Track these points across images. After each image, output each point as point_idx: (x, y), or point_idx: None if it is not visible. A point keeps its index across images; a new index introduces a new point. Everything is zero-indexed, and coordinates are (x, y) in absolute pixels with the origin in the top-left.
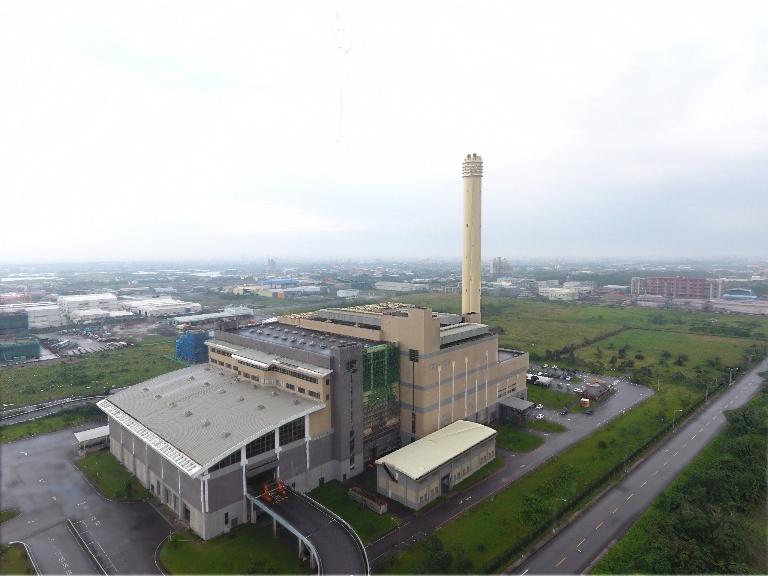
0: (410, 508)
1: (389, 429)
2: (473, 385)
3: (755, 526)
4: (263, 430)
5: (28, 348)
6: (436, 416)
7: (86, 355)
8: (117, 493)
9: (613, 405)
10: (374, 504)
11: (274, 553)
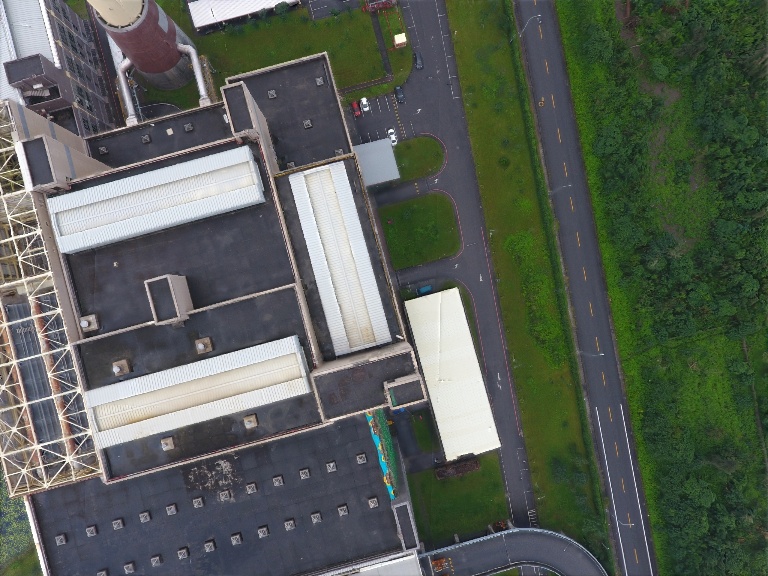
0: None
1: None
2: None
3: (658, 191)
4: None
5: None
6: None
7: None
8: None
9: (418, 2)
10: None
11: None
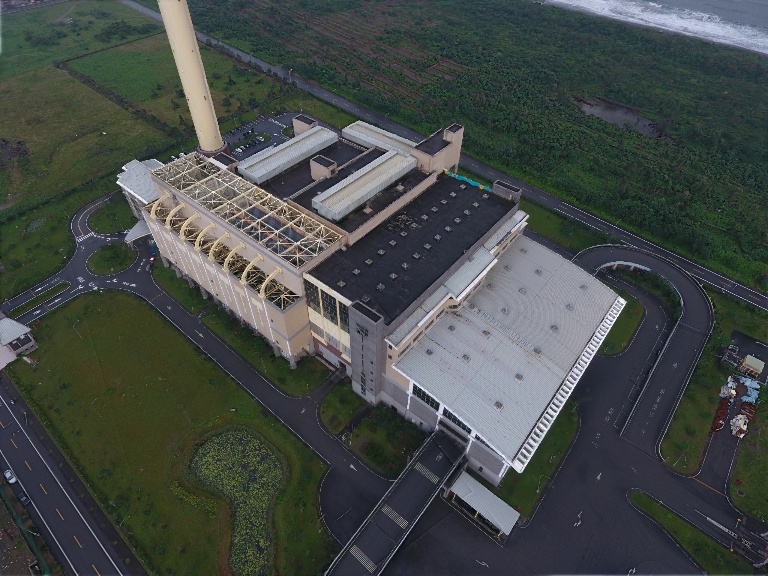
0: None
1: None
2: None
3: (488, 143)
4: None
5: None
6: None
7: None
8: None
9: None
10: None
11: None
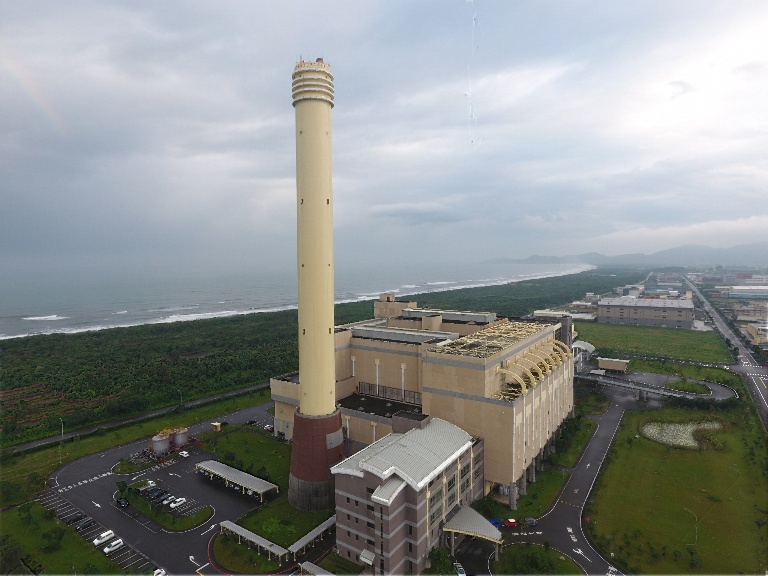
0: None
1: None
2: None
3: None
4: None
5: None
6: None
7: None
8: None
9: None
10: None
11: None
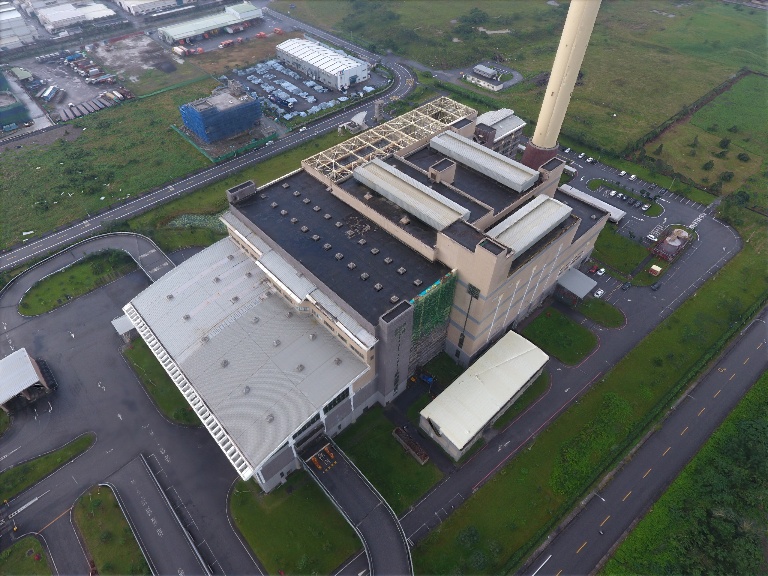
0: (450, 456)
1: (434, 344)
2: (534, 284)
3: None
4: (307, 419)
5: (13, 112)
6: (487, 333)
7: (82, 121)
8: (175, 416)
9: (686, 272)
10: (417, 456)
11: (329, 518)
